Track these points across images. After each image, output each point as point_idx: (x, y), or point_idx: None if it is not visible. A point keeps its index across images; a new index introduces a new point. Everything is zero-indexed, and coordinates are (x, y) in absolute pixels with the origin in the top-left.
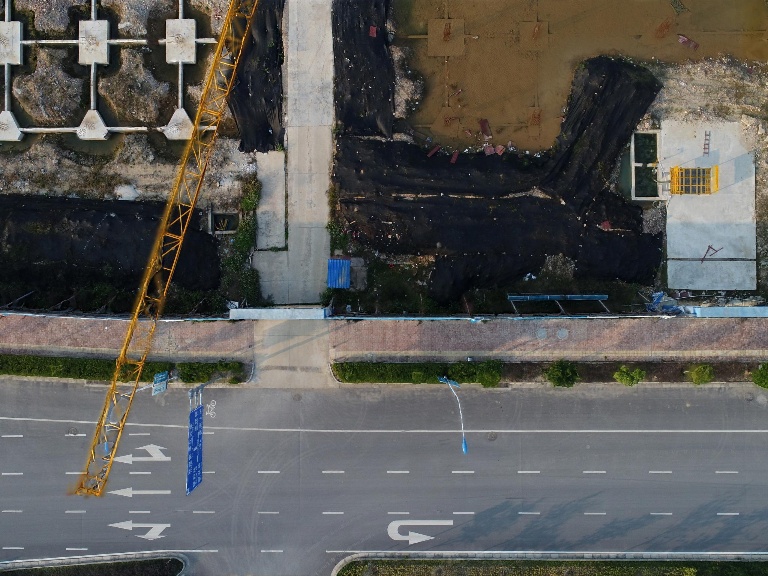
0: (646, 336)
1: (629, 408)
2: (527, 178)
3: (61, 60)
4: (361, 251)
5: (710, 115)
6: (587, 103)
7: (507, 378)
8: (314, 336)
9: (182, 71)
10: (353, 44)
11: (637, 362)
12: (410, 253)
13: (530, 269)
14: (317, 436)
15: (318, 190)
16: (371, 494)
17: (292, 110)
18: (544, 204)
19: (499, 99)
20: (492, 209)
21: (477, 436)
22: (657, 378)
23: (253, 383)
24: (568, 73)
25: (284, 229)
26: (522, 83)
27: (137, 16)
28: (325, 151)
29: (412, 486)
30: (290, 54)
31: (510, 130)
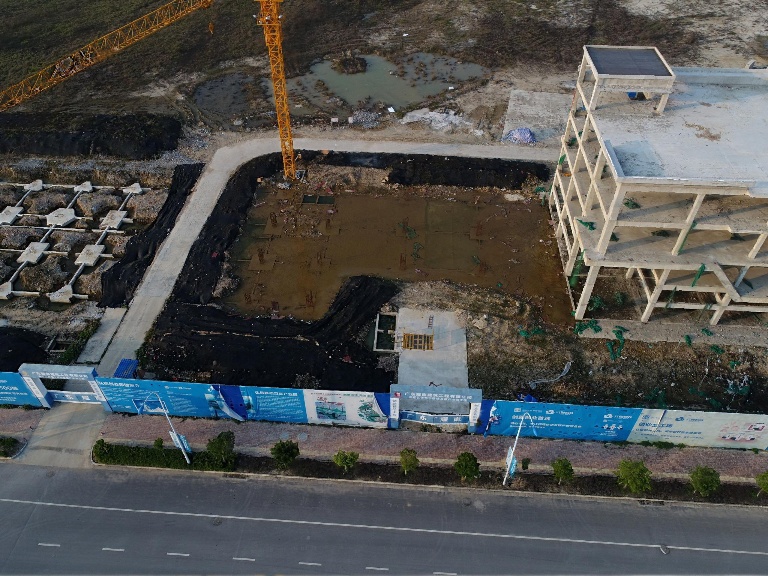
0: (374, 443)
1: (353, 504)
2: (294, 329)
3: (6, 258)
4: (156, 368)
5: (434, 307)
6: (346, 294)
7: (246, 470)
8: (90, 425)
9: (82, 269)
10: (199, 259)
11: (364, 463)
12: (192, 369)
13: (283, 384)
14: (51, 509)
15: (141, 331)
16: (76, 570)
17: (144, 288)
18: (303, 344)
19: (289, 293)
20: (262, 344)
21: (203, 520)
22: (381, 478)
23: (18, 459)
24: (339, 283)
25: (103, 351)
26: (307, 286)
27: (69, 240)
28: (156, 310)
29: (121, 565)
30: (156, 262)
31: (293, 309)
